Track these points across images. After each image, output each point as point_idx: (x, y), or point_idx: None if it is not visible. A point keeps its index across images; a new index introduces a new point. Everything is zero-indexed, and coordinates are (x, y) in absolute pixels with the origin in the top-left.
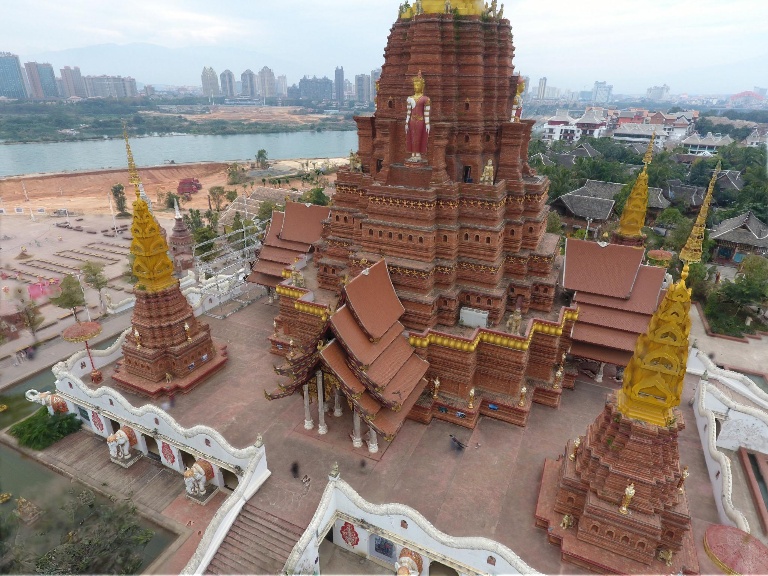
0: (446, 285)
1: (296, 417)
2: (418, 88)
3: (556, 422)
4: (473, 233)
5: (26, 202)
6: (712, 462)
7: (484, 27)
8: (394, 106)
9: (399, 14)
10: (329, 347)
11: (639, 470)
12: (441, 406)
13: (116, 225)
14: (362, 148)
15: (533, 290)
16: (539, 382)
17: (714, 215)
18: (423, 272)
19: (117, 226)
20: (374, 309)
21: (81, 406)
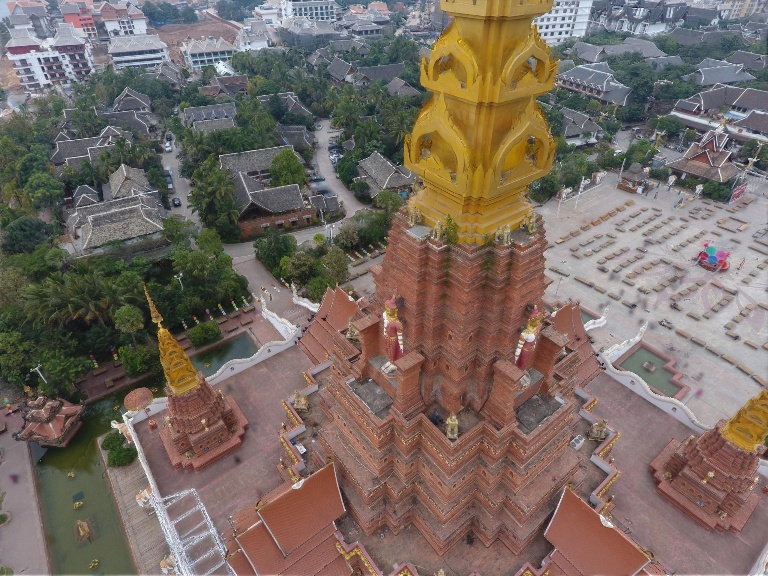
0: None
1: None
2: (538, 323)
3: None
4: None
5: None
6: (662, 403)
7: None
8: None
9: (440, 232)
10: None
11: None
12: None
13: None
14: (406, 389)
15: None
16: None
17: (350, 159)
18: None
19: None
20: None
21: None
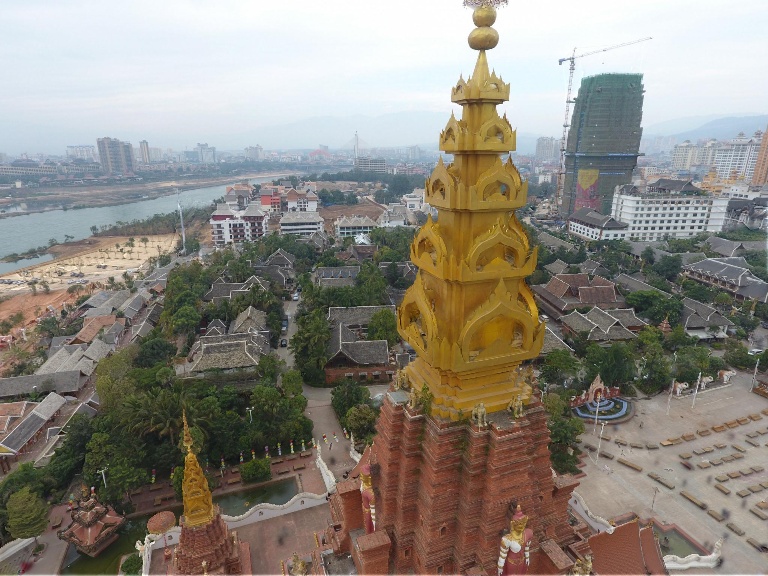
0: None
1: None
2: (523, 529)
3: None
4: None
5: None
6: None
7: None
8: (449, 531)
9: (414, 400)
10: None
11: None
12: None
13: None
14: None
15: None
16: None
17: None
18: None
19: None
20: None
21: None
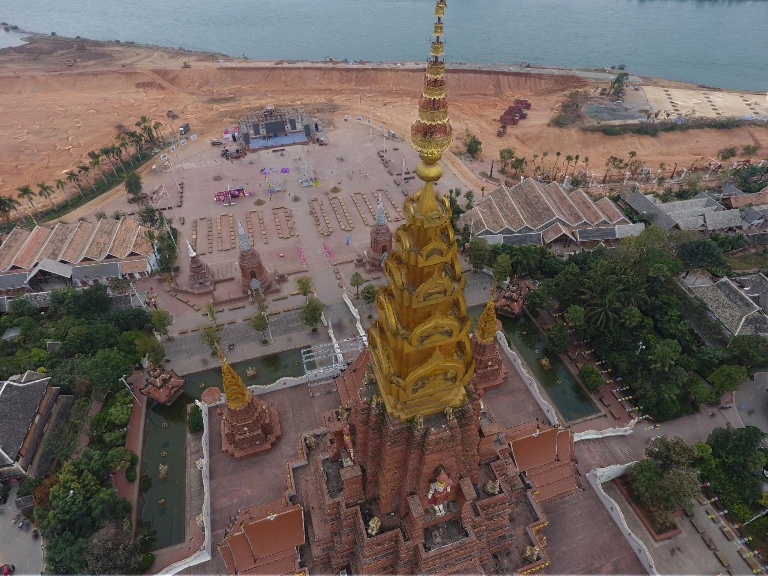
0: None
1: None
2: (345, 435)
3: None
4: None
5: (383, 107)
6: None
7: None
8: None
9: None
10: None
11: None
12: None
13: (412, 167)
14: None
15: None
16: None
17: None
18: None
19: (411, 170)
20: (271, 538)
21: None
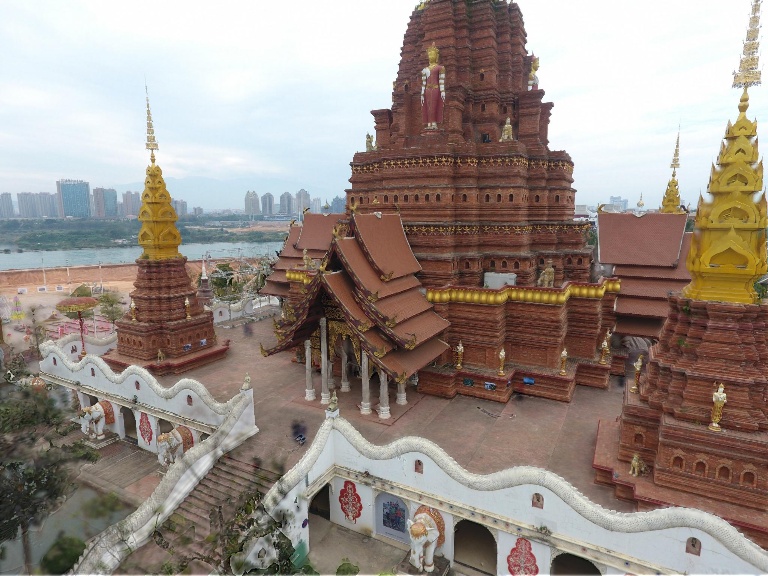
0: (467, 247)
1: (297, 392)
2: (432, 57)
3: (608, 400)
4: (494, 193)
5: (68, 284)
6: None
7: (495, 10)
8: (410, 89)
9: None
10: (334, 275)
11: (727, 368)
12: (466, 377)
13: None
14: (379, 142)
15: (565, 263)
16: (582, 360)
17: None
18: (441, 227)
19: None
20: (387, 253)
21: (62, 386)
